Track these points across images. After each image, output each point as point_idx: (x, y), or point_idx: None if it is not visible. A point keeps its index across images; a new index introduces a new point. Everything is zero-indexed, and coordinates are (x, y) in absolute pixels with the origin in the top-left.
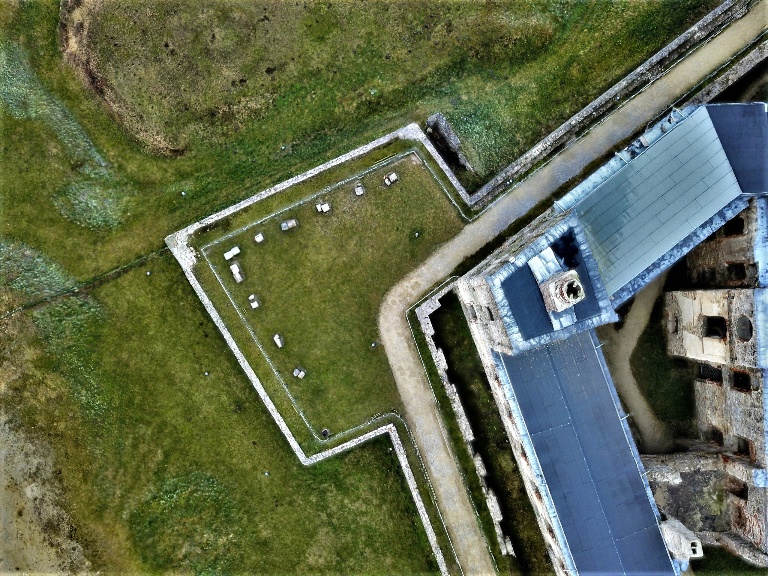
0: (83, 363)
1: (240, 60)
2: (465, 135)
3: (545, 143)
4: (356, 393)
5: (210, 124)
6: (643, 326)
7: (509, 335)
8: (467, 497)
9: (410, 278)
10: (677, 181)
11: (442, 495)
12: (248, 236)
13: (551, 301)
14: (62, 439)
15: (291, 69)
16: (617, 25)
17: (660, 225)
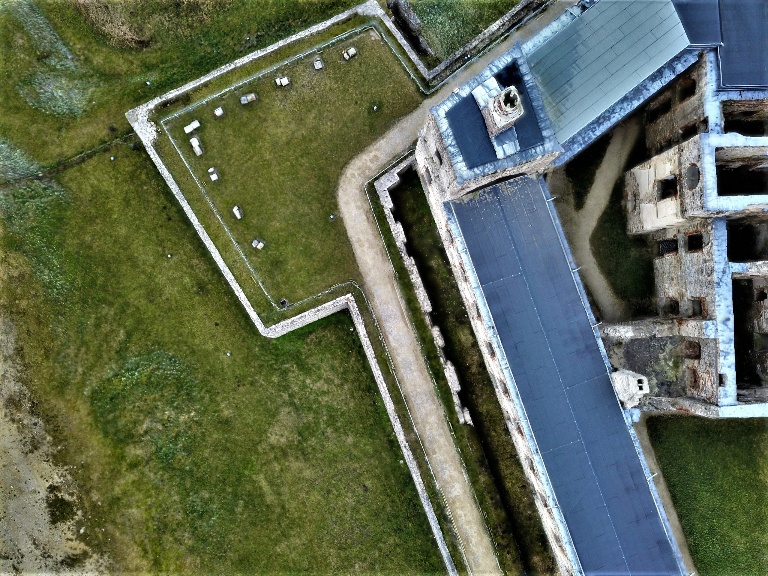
0: (46, 244)
1: None
2: (428, 25)
3: (503, 19)
4: (315, 264)
5: (175, 15)
6: (603, 207)
7: (453, 164)
8: (425, 366)
9: (369, 151)
10: (626, 33)
11: (400, 364)
12: (208, 110)
13: (491, 120)
14: (24, 316)
15: None
16: None
17: (609, 76)
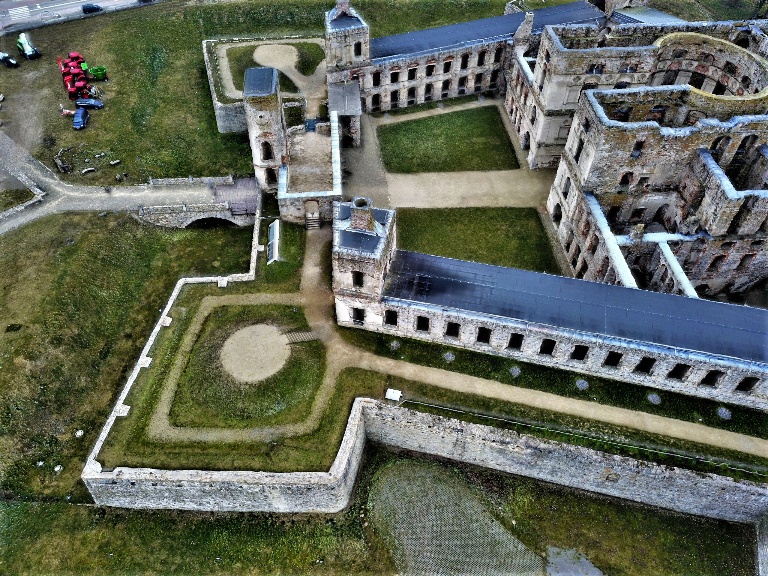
0: None
1: None
2: None
3: None
4: None
5: None
6: None
7: None
8: None
9: None
10: None
11: None
12: None
13: None
14: None
15: None
16: None
17: None
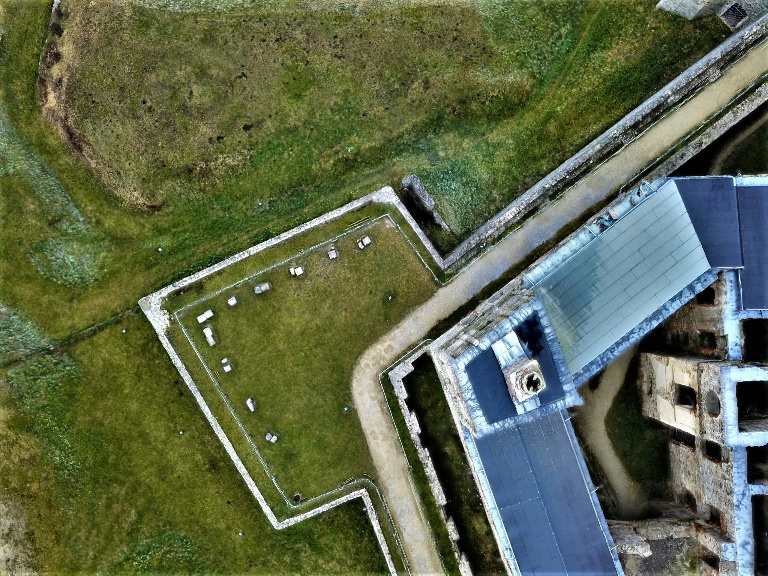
0: (57, 422)
1: (217, 117)
2: (442, 192)
3: (519, 206)
4: (329, 457)
5: (187, 180)
6: (618, 386)
7: (473, 419)
8: (439, 563)
9: (383, 341)
10: (646, 255)
11: (414, 561)
12: (221, 299)
13: (513, 389)
14: (35, 500)
15: (268, 126)
16: (594, 81)
17: (629, 299)
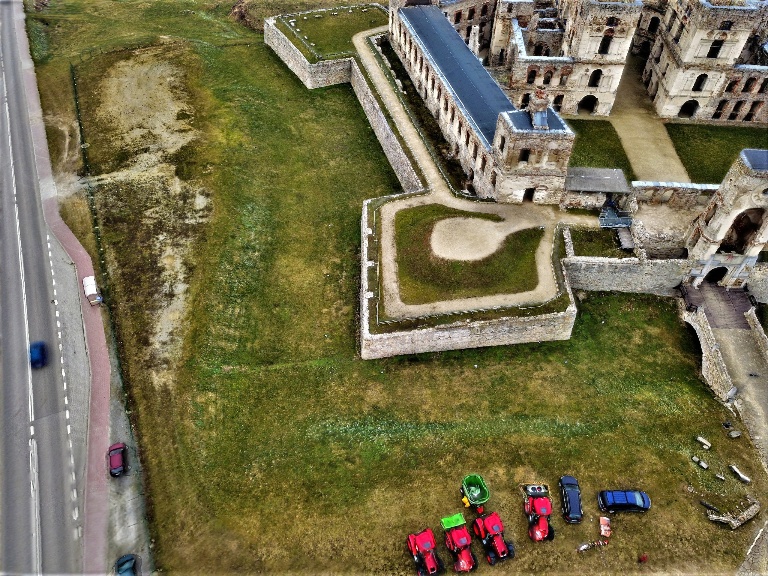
0: None
1: None
2: None
3: None
4: None
5: None
6: None
7: None
8: (385, 77)
9: None
10: None
11: (373, 75)
12: None
13: None
14: None
15: None
16: None
17: None
